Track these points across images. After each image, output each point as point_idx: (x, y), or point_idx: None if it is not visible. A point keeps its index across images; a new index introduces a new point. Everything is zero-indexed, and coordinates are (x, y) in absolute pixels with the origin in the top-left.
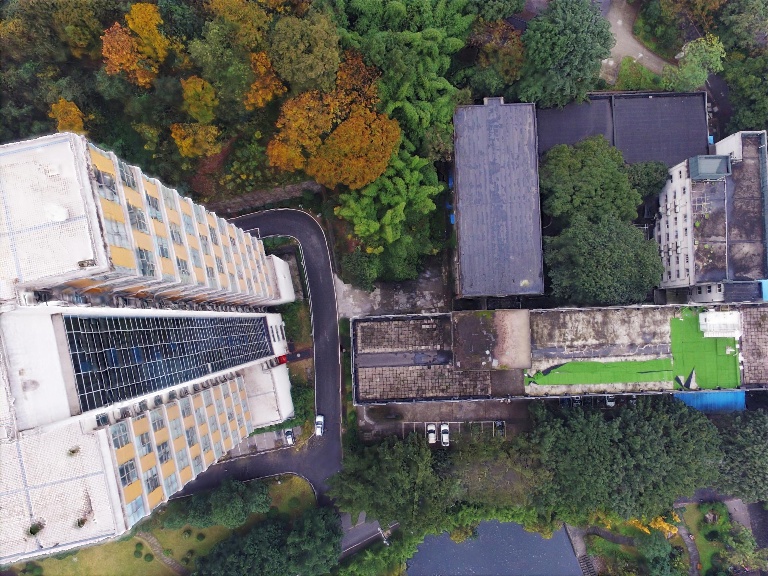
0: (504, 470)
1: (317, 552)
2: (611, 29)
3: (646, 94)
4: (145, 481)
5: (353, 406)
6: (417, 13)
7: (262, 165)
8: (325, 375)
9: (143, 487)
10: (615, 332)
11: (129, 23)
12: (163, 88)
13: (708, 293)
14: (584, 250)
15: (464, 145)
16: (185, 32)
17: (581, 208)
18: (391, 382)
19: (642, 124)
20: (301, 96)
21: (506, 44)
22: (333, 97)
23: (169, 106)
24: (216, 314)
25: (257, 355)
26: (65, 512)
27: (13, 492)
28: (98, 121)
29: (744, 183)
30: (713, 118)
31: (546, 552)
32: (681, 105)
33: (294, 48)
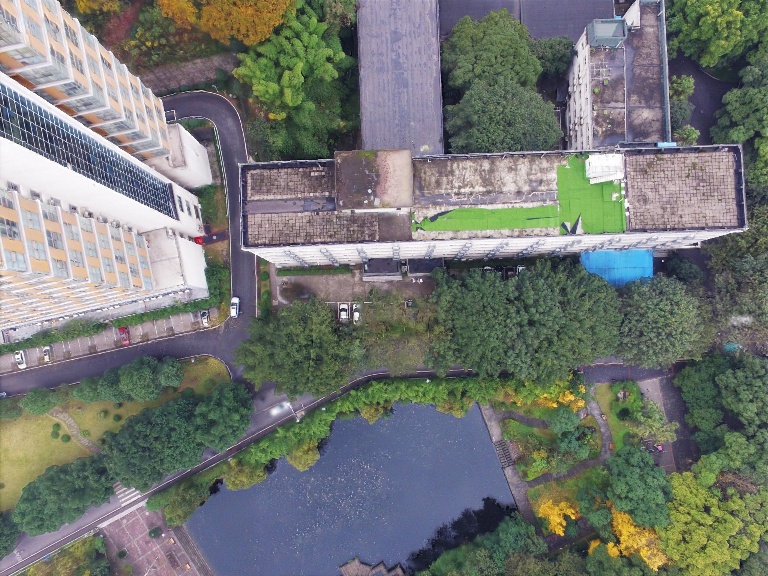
0: (401, 329)
1: (224, 422)
2: None
3: None
4: None
5: (267, 286)
6: None
7: (167, 33)
8: (241, 257)
9: None
10: (502, 179)
11: None
12: None
13: None
14: (478, 107)
15: (366, 15)
16: None
17: (482, 76)
18: (280, 228)
19: (549, 2)
20: None
21: None
22: None
23: None
24: (85, 128)
25: (153, 208)
26: None
27: None
28: None
29: (643, 50)
30: (625, 3)
31: (462, 438)
32: None
33: None
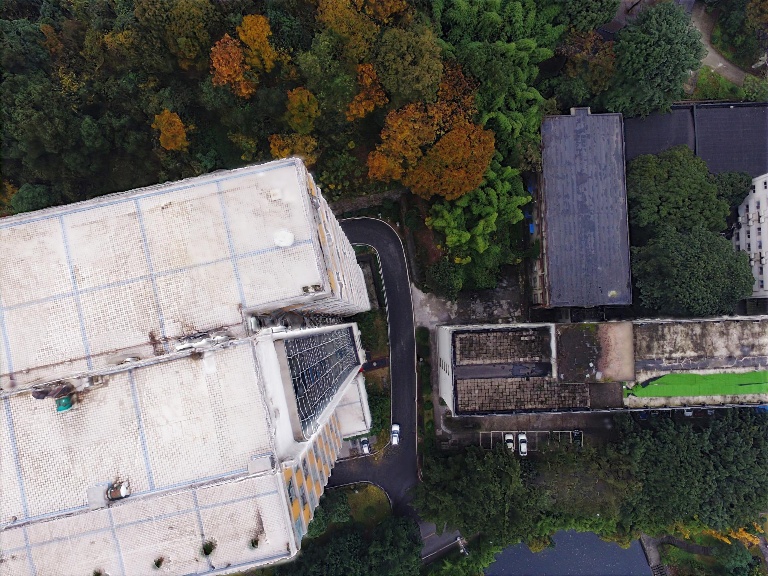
0: (594, 481)
1: (399, 562)
2: None
3: (728, 104)
4: (301, 499)
5: (430, 415)
6: (508, 23)
7: (350, 175)
8: (401, 384)
9: (300, 506)
10: (713, 344)
11: (240, 35)
12: (267, 99)
13: None
14: (677, 261)
15: (551, 155)
16: (291, 43)
17: (668, 218)
18: (490, 394)
19: (724, 134)
20: (405, 108)
21: (598, 55)
22: (438, 109)
23: (268, 117)
24: (336, 328)
25: (351, 366)
26: (237, 532)
27: (184, 512)
28: (192, 131)
29: None
30: None
31: (620, 561)
32: (762, 115)
33: (400, 60)
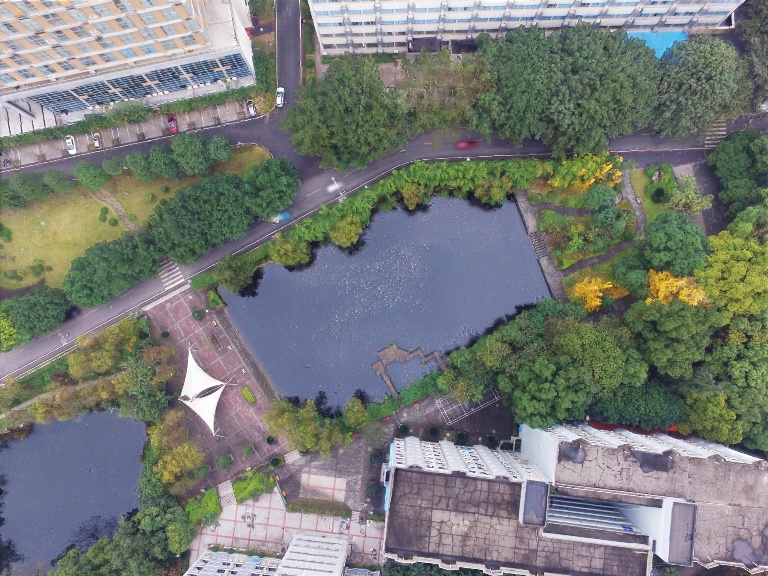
0: (448, 79)
1: (271, 187)
2: None
3: None
4: None
5: (312, 73)
6: None
7: None
8: (286, 49)
9: None
10: None
11: None
12: None
13: None
14: None
15: None
16: None
17: None
18: None
19: None
20: None
21: None
22: None
23: None
24: None
25: None
26: None
27: None
28: None
29: None
30: None
31: (499, 229)
32: None
33: None
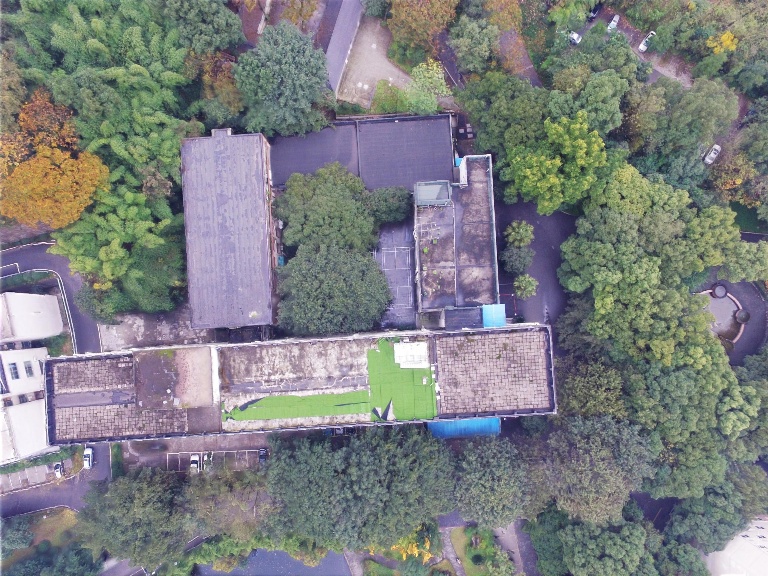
0: (229, 504)
1: None
2: (365, 53)
3: (391, 118)
4: None
5: None
6: (131, 48)
7: None
8: None
9: None
10: (312, 365)
11: None
12: None
13: (442, 319)
14: (296, 282)
15: (192, 178)
16: None
17: (312, 237)
18: (88, 422)
19: (387, 149)
20: None
21: (218, 77)
22: (6, 140)
23: None
24: None
25: None
26: None
27: None
28: None
29: (473, 207)
30: None
31: None
32: (427, 128)
33: None
